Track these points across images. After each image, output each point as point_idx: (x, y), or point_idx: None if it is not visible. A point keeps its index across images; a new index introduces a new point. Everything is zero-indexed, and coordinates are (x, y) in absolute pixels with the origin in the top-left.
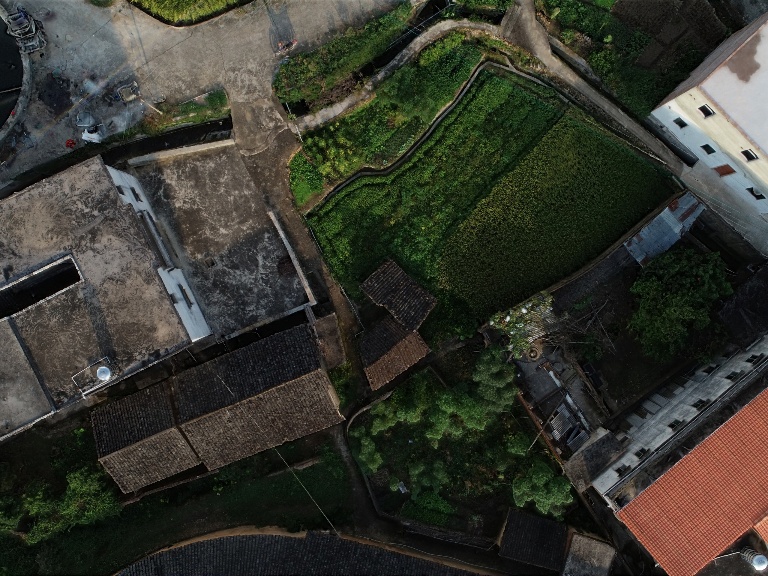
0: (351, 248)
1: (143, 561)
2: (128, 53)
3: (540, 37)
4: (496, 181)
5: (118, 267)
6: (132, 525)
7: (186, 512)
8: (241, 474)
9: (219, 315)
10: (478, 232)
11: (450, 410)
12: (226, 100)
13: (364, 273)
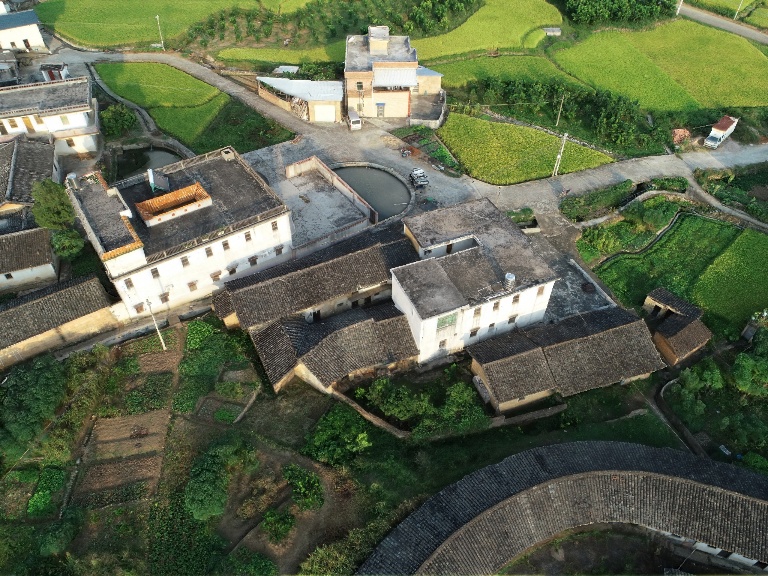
0: (627, 287)
1: (522, 453)
2: (471, 194)
3: (712, 199)
4: (714, 259)
5: (504, 241)
6: (496, 444)
7: (541, 440)
8: (583, 415)
9: (545, 312)
10: (714, 281)
11: (750, 363)
12: (533, 212)
13: (641, 301)
